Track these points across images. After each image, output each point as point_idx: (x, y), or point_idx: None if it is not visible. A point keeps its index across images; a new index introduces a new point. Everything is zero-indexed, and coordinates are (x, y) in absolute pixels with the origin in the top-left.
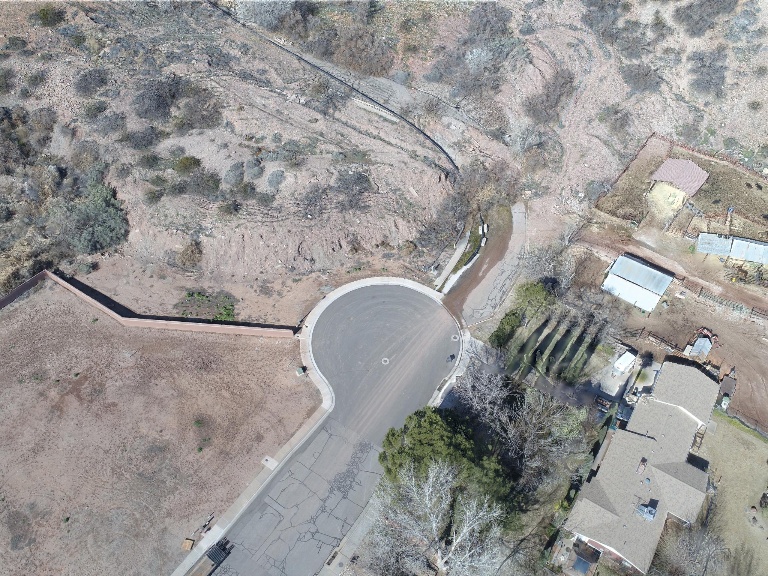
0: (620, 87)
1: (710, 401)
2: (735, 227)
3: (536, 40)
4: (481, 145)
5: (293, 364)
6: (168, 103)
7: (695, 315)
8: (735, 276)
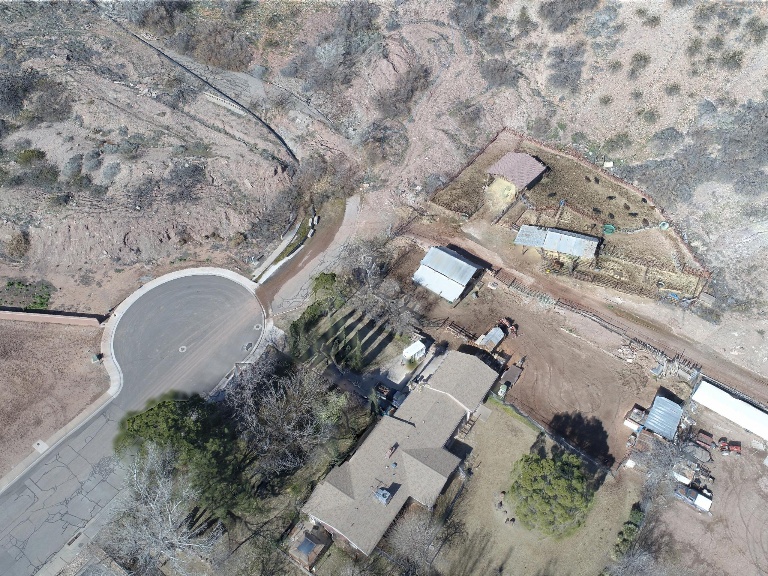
0: (476, 82)
1: (483, 389)
2: (563, 220)
3: (399, 35)
4: (323, 138)
5: (91, 351)
6: (20, 97)
7: (502, 306)
8: (550, 268)
